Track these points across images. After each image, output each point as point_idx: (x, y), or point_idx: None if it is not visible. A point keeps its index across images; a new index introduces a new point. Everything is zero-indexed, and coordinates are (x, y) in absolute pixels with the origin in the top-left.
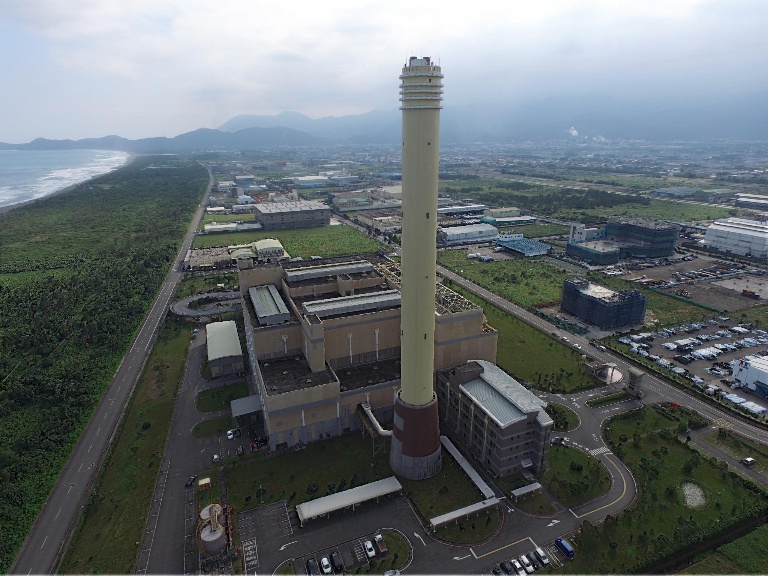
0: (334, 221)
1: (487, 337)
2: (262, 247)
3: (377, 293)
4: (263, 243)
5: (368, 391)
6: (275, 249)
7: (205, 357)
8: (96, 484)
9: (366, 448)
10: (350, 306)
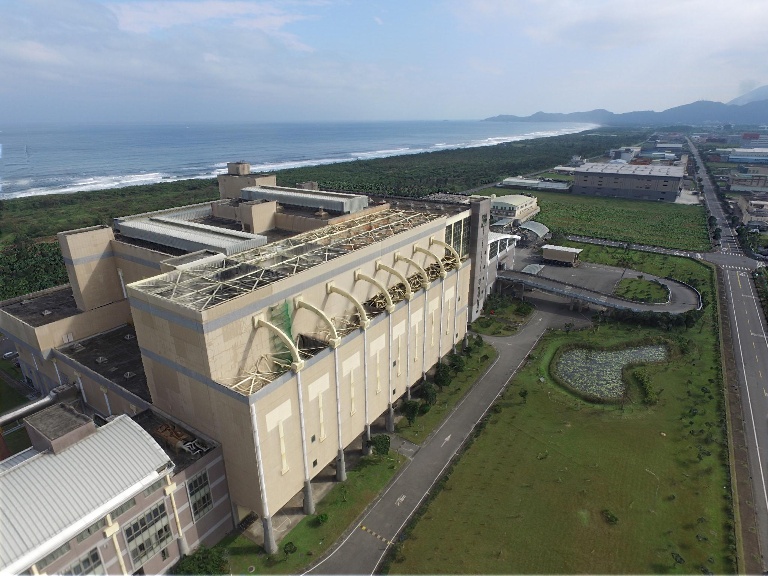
0: (692, 199)
1: (227, 397)
2: (493, 200)
3: (228, 231)
4: (505, 197)
5: (78, 370)
6: (506, 205)
7: None
8: None
9: (21, 448)
10: (156, 233)
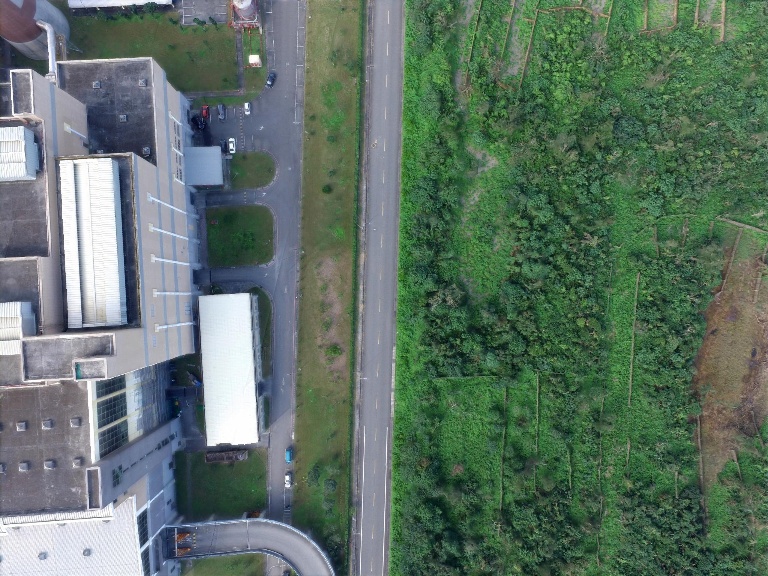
0: None
1: None
2: None
3: None
4: None
5: None
6: None
7: (269, 368)
8: (359, 98)
9: None
10: None
